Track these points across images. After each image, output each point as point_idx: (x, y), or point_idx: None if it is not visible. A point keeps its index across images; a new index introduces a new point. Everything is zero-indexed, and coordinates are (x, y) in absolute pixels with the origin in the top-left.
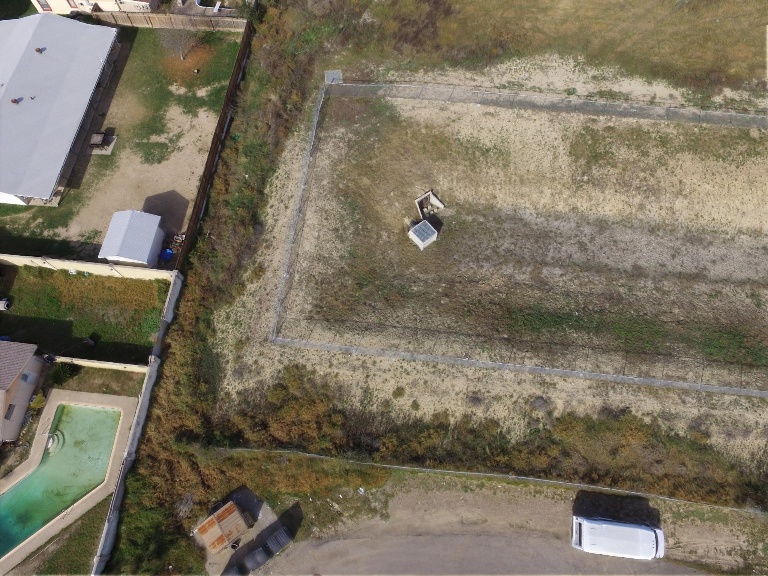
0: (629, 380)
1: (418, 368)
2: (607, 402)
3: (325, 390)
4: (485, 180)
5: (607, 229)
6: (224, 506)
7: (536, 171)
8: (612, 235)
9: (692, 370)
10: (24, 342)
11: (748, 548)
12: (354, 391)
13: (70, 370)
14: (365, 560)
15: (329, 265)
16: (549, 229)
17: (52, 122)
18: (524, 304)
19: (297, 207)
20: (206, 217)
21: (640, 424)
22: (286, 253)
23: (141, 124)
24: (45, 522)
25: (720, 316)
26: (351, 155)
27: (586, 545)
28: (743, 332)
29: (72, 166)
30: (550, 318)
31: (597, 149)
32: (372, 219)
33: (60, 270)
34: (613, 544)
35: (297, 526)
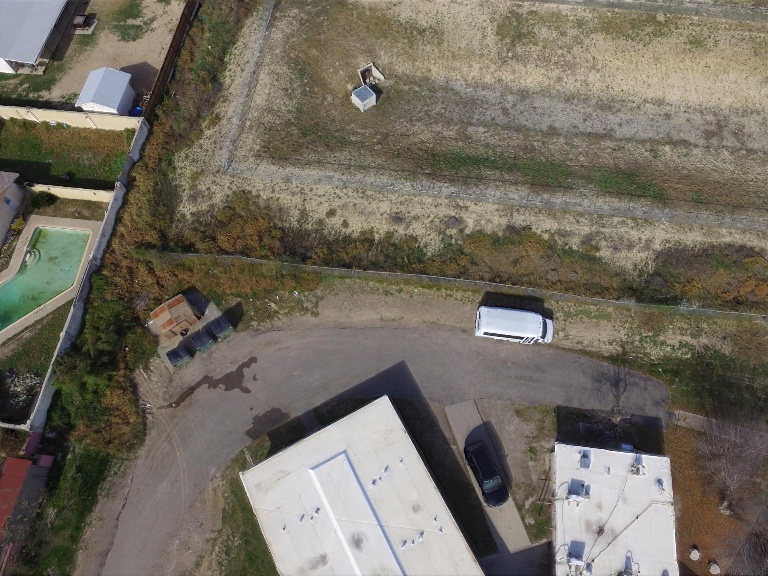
0: (532, 204)
1: (349, 194)
2: (511, 221)
3: (267, 210)
4: (421, 56)
5: (528, 98)
6: (174, 297)
7: (466, 48)
8: (532, 103)
9: (587, 198)
10: (7, 171)
11: (627, 340)
12: (293, 212)
13: (47, 197)
14: (295, 346)
15: (277, 116)
16: (476, 97)
17: (40, 3)
18: (447, 151)
19: (252, 70)
20: (172, 81)
21: (538, 238)
22: (240, 105)
23: (120, 10)
24: (20, 317)
25: (619, 163)
26: (302, 30)
27: (482, 324)
28: (637, 174)
29: (57, 43)
30: (469, 160)
31: (521, 29)
32: (319, 84)
33: (42, 122)
34: (505, 323)
35: (238, 320)
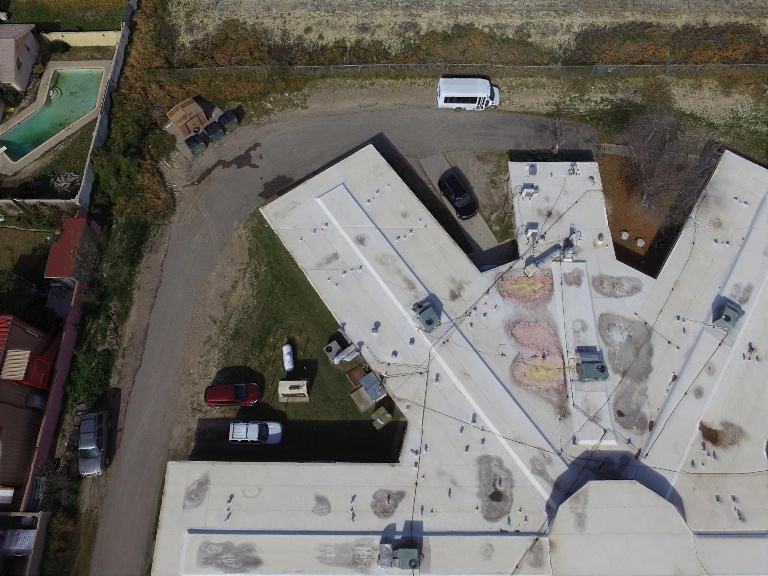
0: (472, 8)
1: (321, 14)
2: (457, 21)
3: (254, 32)
4: None
5: None
6: (185, 100)
7: None
8: None
9: None
10: (24, 23)
11: (560, 101)
12: (276, 33)
13: (61, 43)
14: (292, 132)
15: None
16: None
17: None
18: None
19: None
20: None
21: (481, 31)
22: None
23: None
24: None
25: None
26: None
27: (442, 90)
28: None
29: None
30: None
31: None
32: None
33: None
34: (460, 87)
35: (241, 118)
